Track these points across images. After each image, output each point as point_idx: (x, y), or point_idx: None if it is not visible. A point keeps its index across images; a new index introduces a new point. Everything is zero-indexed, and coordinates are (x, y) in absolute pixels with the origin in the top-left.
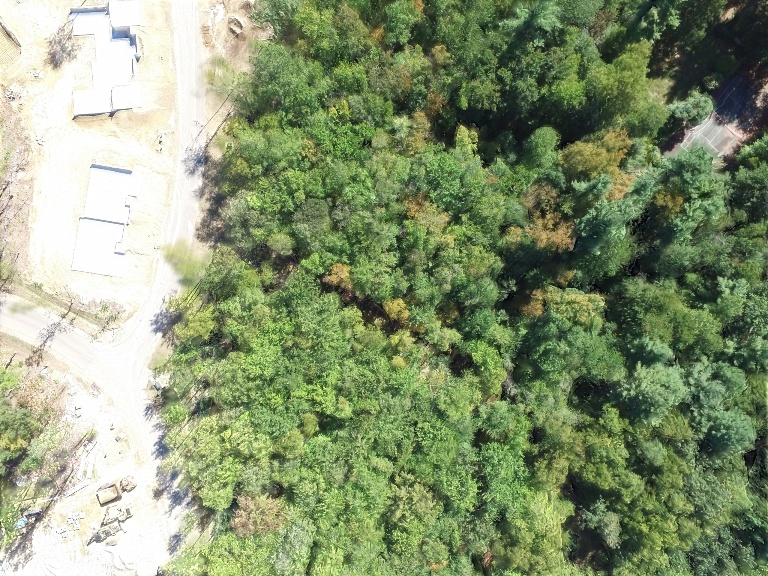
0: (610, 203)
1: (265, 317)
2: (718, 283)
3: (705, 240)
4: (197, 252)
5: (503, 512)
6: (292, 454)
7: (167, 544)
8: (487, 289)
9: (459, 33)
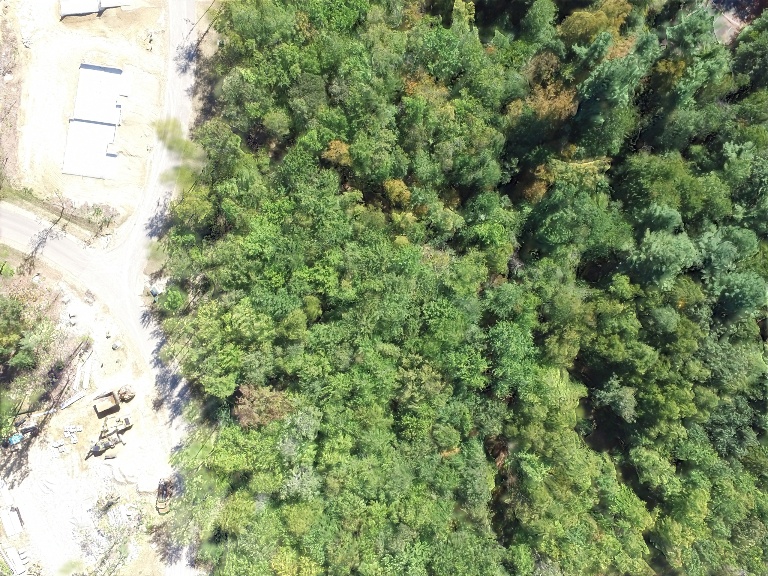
0: (612, 61)
1: (263, 197)
2: (724, 149)
3: (709, 104)
4: (191, 153)
5: (515, 388)
6: (295, 334)
7: (168, 456)
8: (490, 165)
9: None
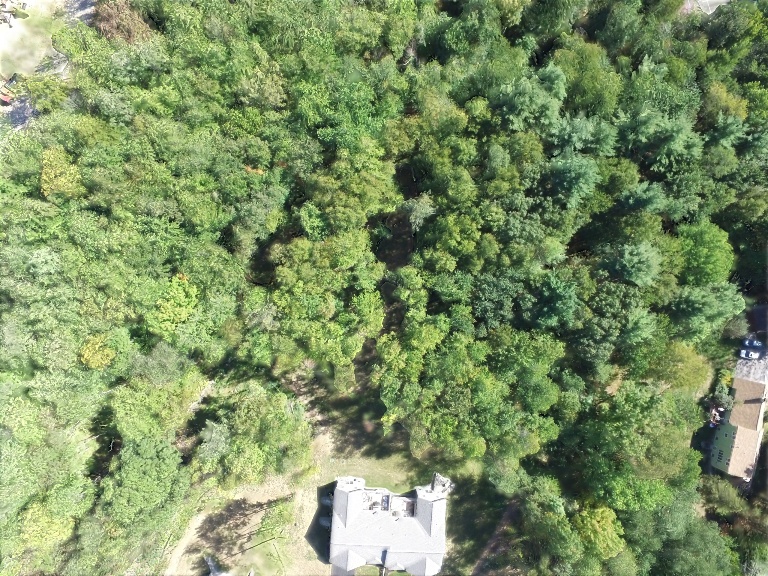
0: None
1: None
2: (642, 61)
3: (652, 12)
4: None
5: (336, 135)
6: None
7: (39, 61)
8: None
9: None
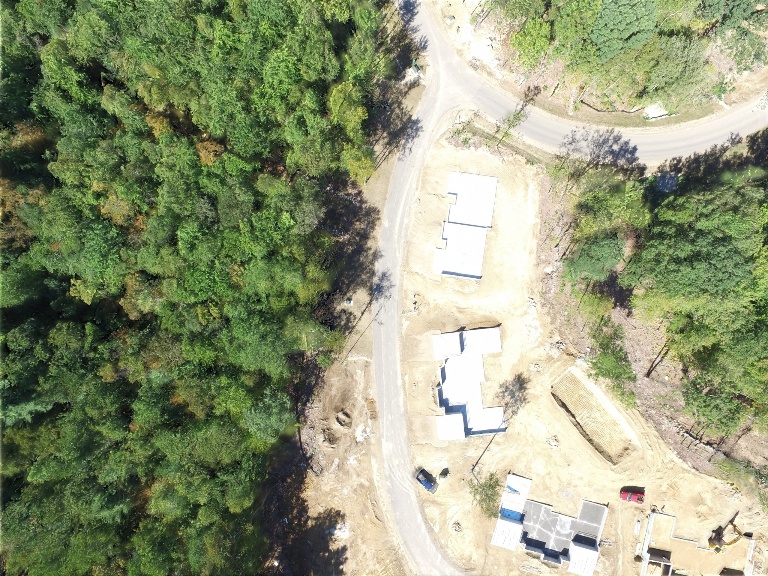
0: None
1: None
2: None
3: None
4: (379, 198)
5: None
6: None
7: None
8: None
9: (92, 397)
